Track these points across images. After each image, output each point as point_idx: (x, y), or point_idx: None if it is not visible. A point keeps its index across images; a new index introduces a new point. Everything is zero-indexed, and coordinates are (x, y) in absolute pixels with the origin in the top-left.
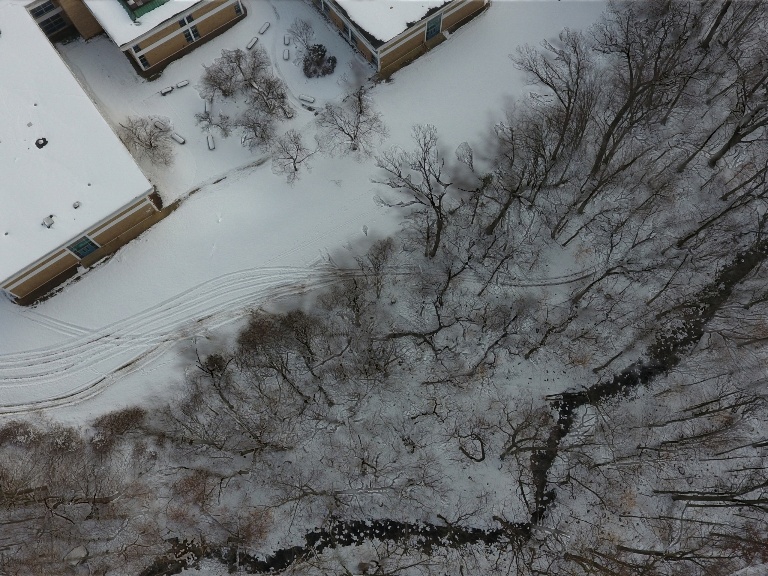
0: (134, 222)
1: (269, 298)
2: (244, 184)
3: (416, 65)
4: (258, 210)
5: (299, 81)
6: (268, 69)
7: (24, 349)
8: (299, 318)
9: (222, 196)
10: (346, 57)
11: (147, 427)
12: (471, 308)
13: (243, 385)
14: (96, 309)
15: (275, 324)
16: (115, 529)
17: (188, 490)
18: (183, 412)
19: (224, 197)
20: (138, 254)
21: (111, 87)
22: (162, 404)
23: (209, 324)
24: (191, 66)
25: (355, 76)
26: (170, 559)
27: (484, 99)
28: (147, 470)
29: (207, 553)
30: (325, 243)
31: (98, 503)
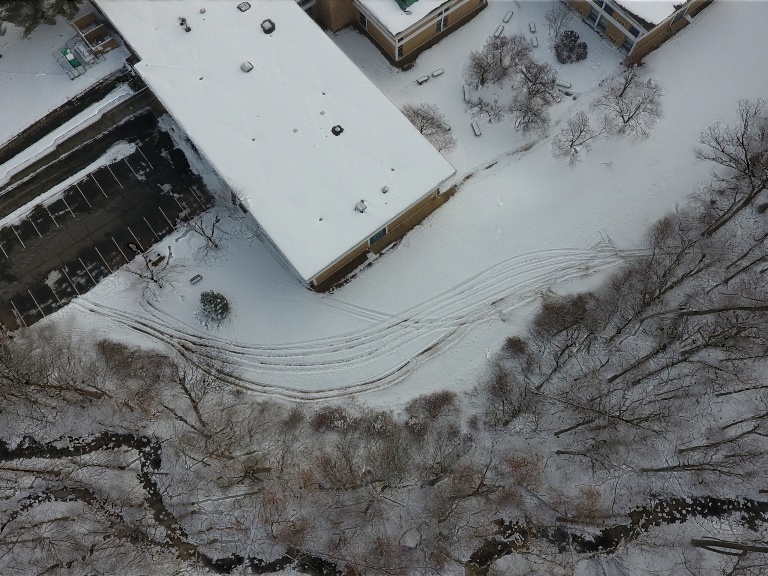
0: (418, 208)
1: (556, 280)
2: (516, 169)
3: (665, 49)
4: (537, 193)
5: None
6: (530, 55)
7: (328, 335)
8: (590, 299)
9: (497, 181)
10: (594, 43)
11: (458, 410)
12: (755, 285)
13: (545, 366)
14: (392, 294)
15: (567, 305)
16: (445, 511)
17: (511, 471)
18: (492, 394)
19: (499, 182)
20: (425, 239)
21: None
22: (469, 387)
23: (502, 307)
24: (442, 55)
25: (607, 61)
26: (498, 540)
27: (736, 80)
28: (464, 452)
29: (533, 534)
30: (603, 225)
31: (426, 485)
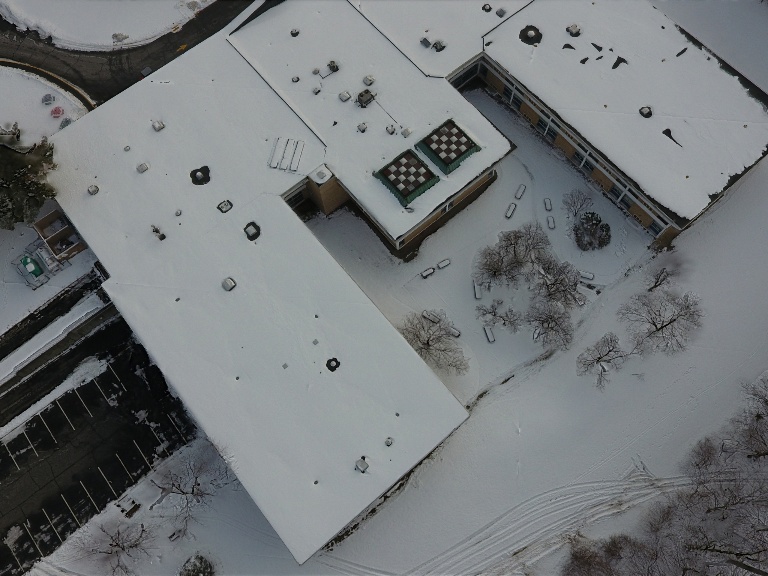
0: None
1: (586, 520)
2: (536, 383)
3: (697, 228)
4: (560, 416)
5: (572, 254)
6: (548, 248)
7: None
8: (625, 544)
9: (515, 399)
10: (617, 222)
11: None
12: None
13: None
14: (400, 549)
15: (599, 553)
16: None
17: None
18: None
19: (517, 401)
20: (435, 477)
21: (365, 271)
22: None
23: (526, 558)
24: (449, 241)
25: (632, 245)
26: None
27: None
28: None
29: None
30: (637, 449)
31: None
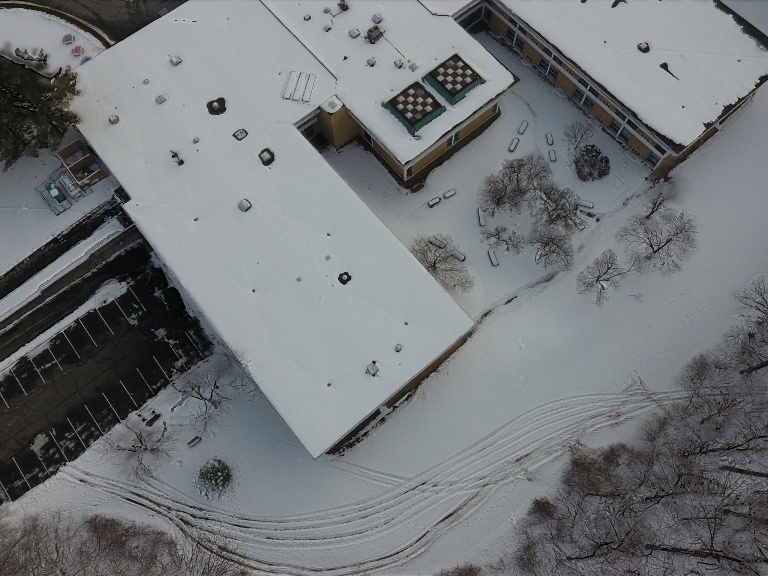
0: None
1: (585, 430)
2: (538, 303)
3: (693, 161)
4: (561, 333)
5: (573, 185)
6: (549, 177)
7: (339, 504)
8: (622, 452)
9: (518, 318)
10: (616, 155)
11: None
12: None
13: (577, 532)
14: (408, 454)
15: (598, 460)
16: None
17: None
18: (520, 567)
19: (520, 319)
20: (442, 389)
21: (374, 200)
22: (494, 559)
23: (528, 464)
24: (454, 173)
25: (631, 176)
26: None
27: None
28: None
29: None
30: (634, 365)
31: None
